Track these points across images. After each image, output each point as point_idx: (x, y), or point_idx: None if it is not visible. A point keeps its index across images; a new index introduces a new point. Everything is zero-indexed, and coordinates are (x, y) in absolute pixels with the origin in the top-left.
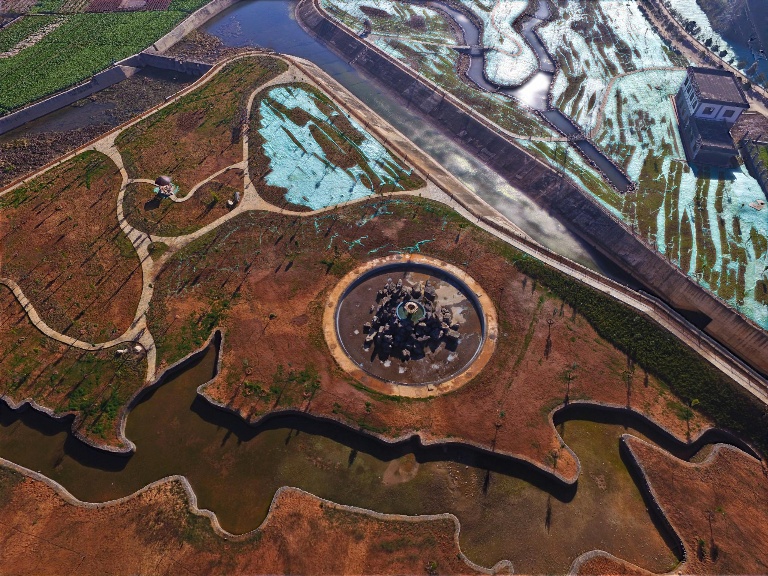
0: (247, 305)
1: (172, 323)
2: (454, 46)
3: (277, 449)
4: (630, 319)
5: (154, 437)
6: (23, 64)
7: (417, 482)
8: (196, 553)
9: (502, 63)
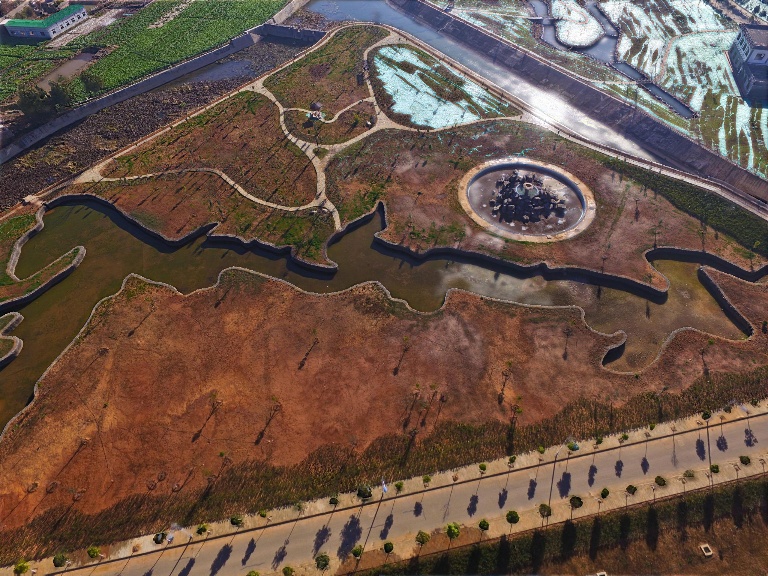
0: (399, 187)
1: (345, 196)
2: (528, 17)
3: (440, 271)
4: (702, 196)
5: (349, 262)
6: (170, 33)
7: (547, 291)
8: (400, 320)
9: (572, 29)
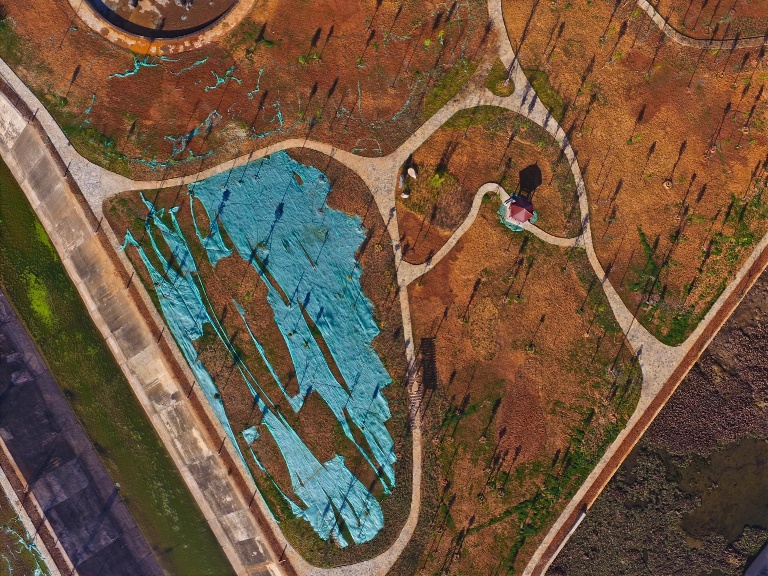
0: None
1: None
2: None
3: None
4: None
5: None
6: None
7: None
8: None
9: None
